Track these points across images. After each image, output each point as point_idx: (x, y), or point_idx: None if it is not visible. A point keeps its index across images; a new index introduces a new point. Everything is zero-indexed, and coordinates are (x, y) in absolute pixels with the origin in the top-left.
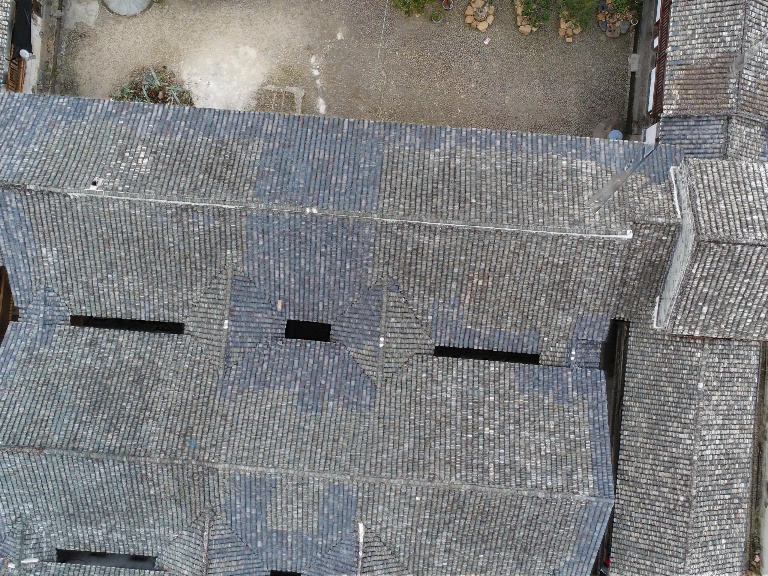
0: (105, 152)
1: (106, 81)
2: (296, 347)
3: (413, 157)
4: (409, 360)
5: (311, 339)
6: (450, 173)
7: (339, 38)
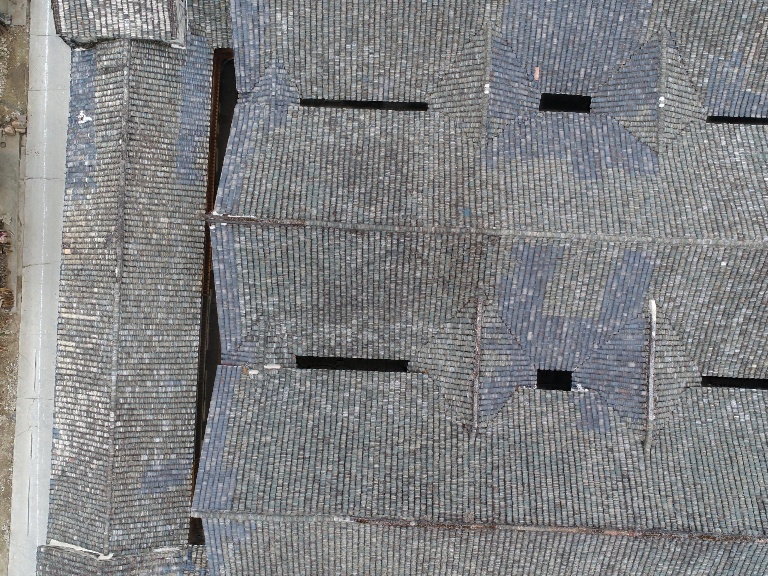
0: None
1: None
2: (558, 119)
3: None
4: (686, 127)
5: (572, 111)
6: None
7: None
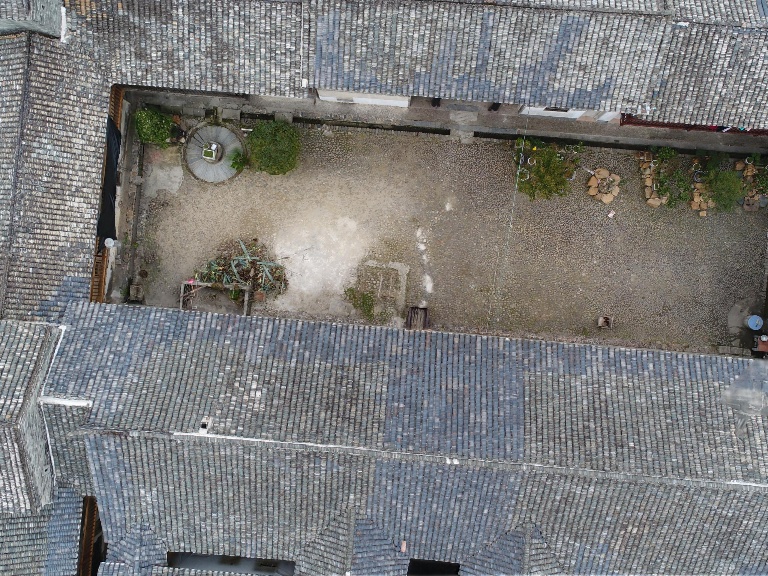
0: (212, 381)
1: (191, 255)
2: None
3: (558, 386)
4: None
5: None
6: (601, 407)
7: (448, 209)
